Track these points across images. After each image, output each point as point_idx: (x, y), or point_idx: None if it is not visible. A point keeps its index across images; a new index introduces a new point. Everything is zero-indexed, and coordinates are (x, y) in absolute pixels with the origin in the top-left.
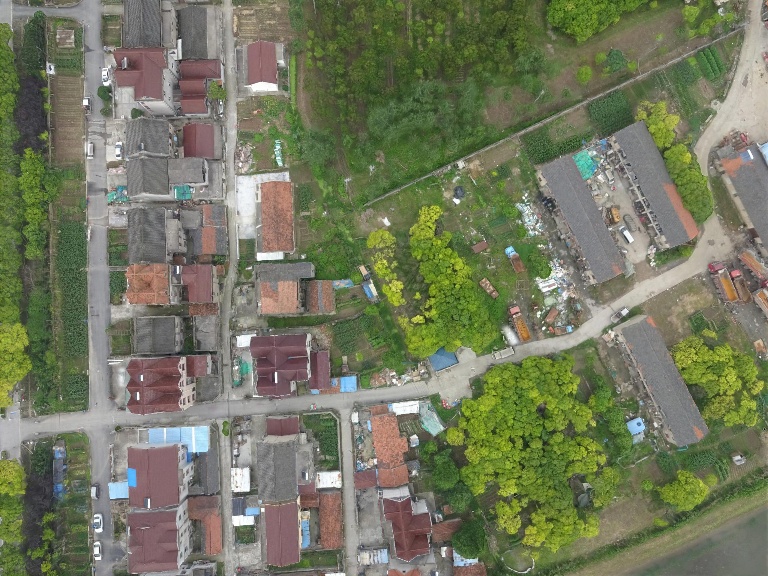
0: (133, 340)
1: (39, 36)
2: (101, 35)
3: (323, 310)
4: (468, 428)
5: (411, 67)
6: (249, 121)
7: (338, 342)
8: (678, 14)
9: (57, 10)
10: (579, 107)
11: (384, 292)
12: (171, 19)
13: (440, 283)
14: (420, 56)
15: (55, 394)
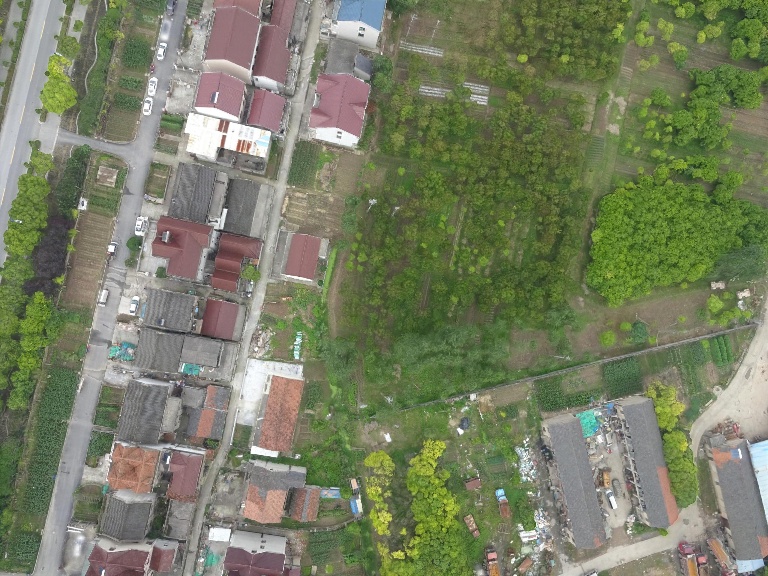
0: (101, 518)
1: (81, 174)
2: (145, 183)
3: (305, 520)
4: None
5: (448, 292)
6: (275, 305)
7: (312, 551)
8: (703, 297)
9: (105, 144)
10: (595, 364)
11: (371, 518)
12: (223, 192)
13: (428, 524)
14: (459, 286)
15: (1, 552)
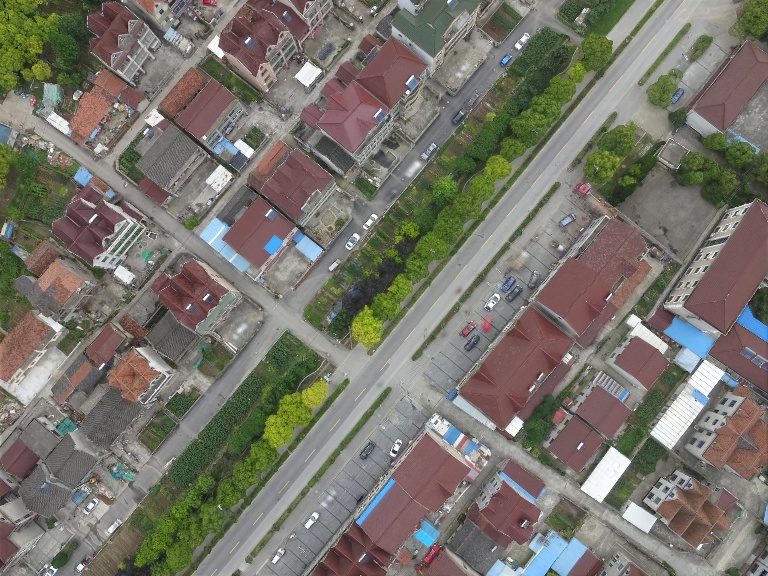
0: (192, 347)
1: None
2: None
3: (47, 246)
4: (18, 66)
5: None
6: None
7: None
8: None
9: None
10: None
11: None
12: None
13: None
14: None
15: None
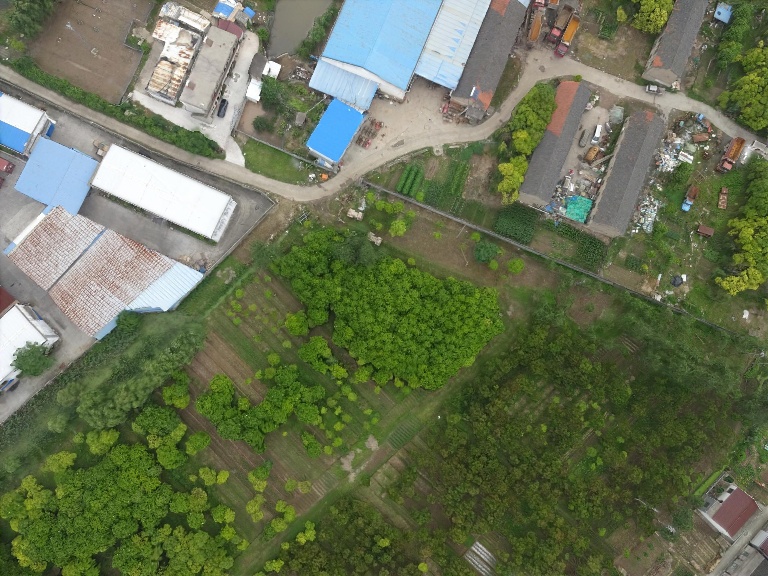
0: None
1: None
2: None
3: None
4: None
5: (628, 401)
6: None
7: None
8: (394, 238)
9: None
10: None
11: None
12: None
13: None
14: (622, 400)
15: None
